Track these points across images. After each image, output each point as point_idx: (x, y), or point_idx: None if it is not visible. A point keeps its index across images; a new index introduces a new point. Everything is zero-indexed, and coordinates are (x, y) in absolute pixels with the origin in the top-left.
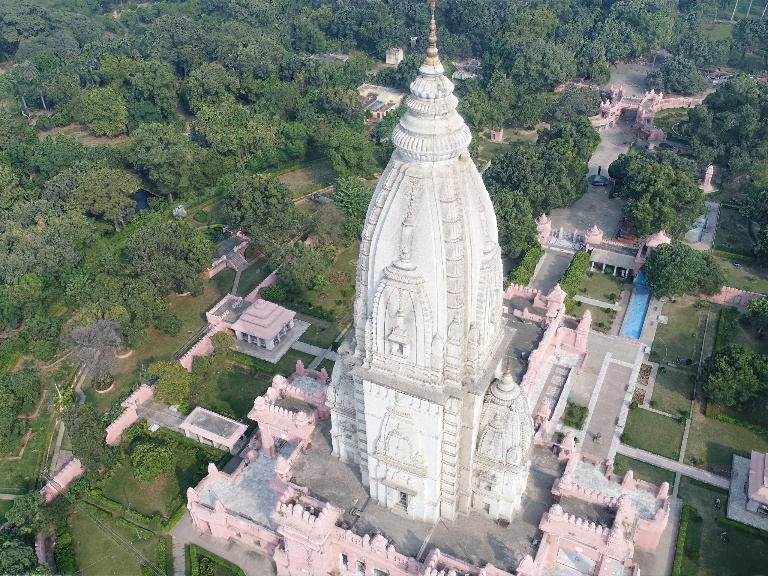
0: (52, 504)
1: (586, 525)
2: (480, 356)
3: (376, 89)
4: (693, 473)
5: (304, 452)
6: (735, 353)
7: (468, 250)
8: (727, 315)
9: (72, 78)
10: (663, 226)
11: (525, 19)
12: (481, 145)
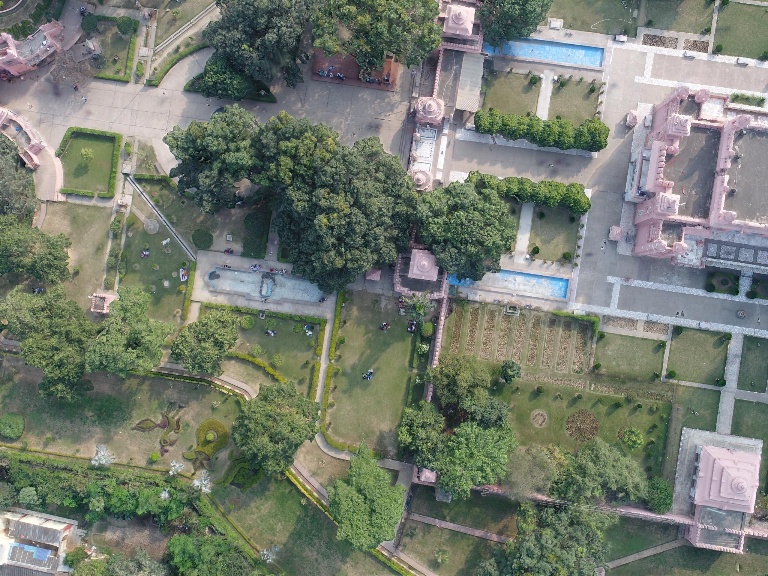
0: None
1: None
2: None
3: None
4: None
5: None
6: None
7: None
8: None
9: None
10: None
11: None
12: None
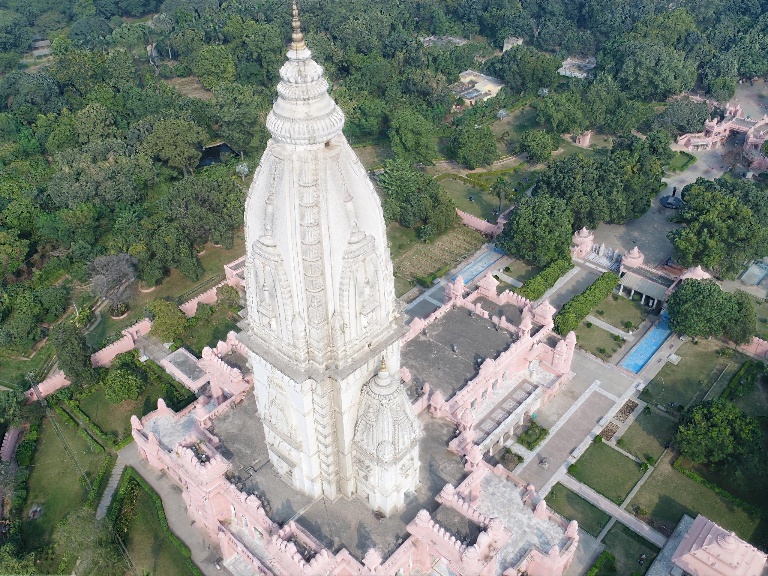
0: (31, 403)
1: (446, 537)
2: (346, 344)
3: (478, 77)
4: (630, 522)
5: (232, 406)
6: (715, 408)
7: (324, 237)
8: (750, 369)
9: (196, 33)
10: (706, 260)
11: (655, 21)
12: (563, 147)
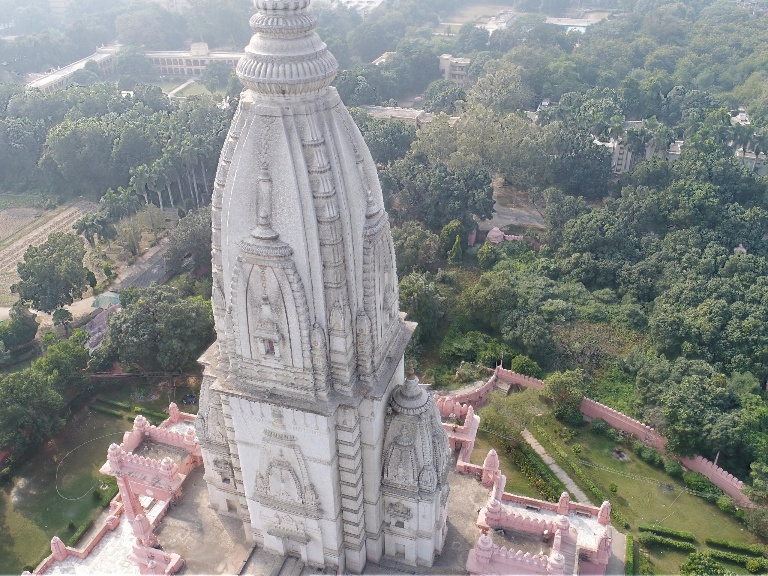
0: None
1: None
2: None
3: None
4: None
5: None
6: None
7: None
8: None
9: None
10: None
11: None
12: None
